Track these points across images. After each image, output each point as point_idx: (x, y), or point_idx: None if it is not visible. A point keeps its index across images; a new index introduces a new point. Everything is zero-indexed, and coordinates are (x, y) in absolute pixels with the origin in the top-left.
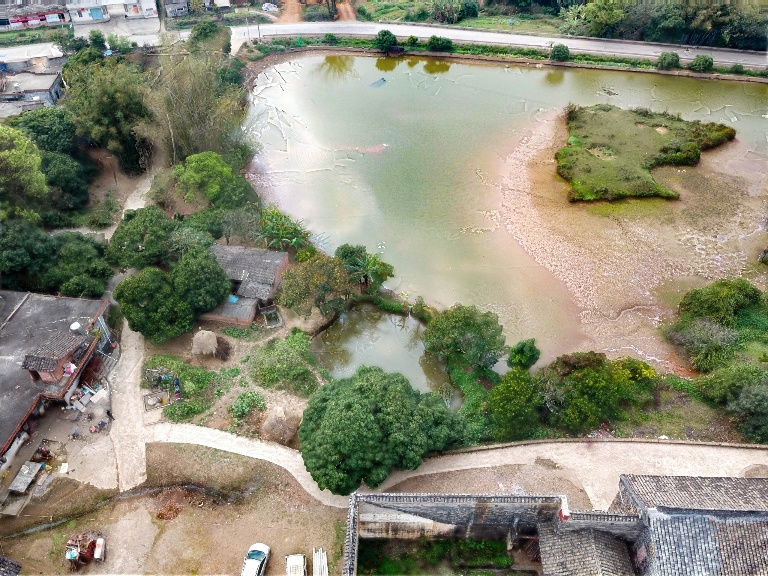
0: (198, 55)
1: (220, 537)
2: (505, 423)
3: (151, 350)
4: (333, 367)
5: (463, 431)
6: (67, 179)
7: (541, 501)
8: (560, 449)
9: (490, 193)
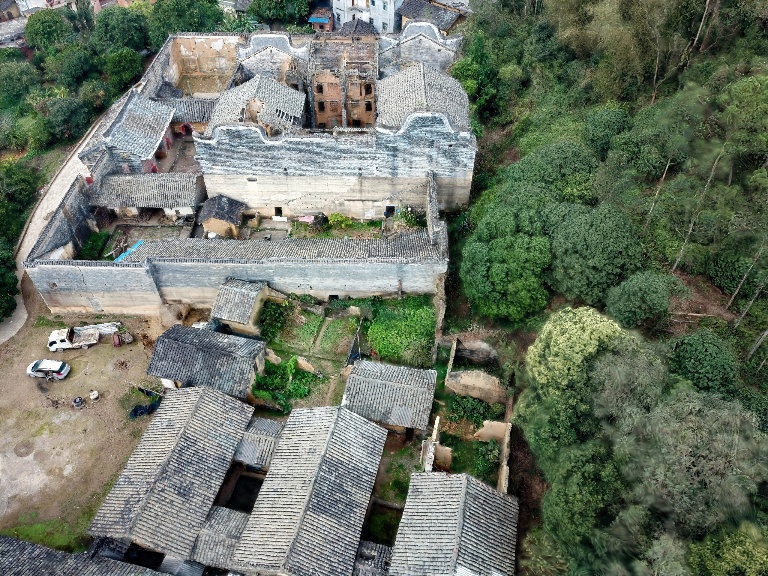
0: None
1: (8, 400)
2: (8, 221)
3: None
4: None
5: None
6: None
7: (76, 183)
8: (43, 207)
9: None
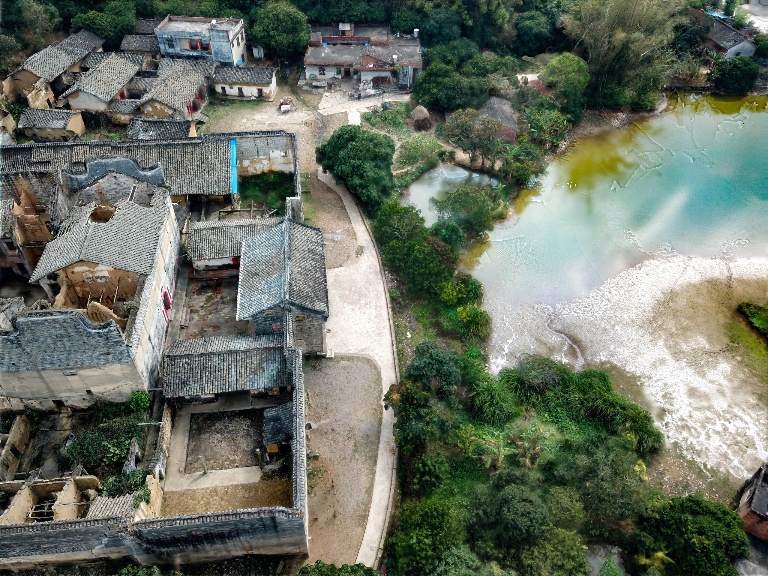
0: (665, 4)
1: (297, 140)
2: None
3: (411, 103)
4: (430, 175)
5: (364, 196)
6: (526, 32)
7: None
8: (372, 257)
9: (706, 248)
